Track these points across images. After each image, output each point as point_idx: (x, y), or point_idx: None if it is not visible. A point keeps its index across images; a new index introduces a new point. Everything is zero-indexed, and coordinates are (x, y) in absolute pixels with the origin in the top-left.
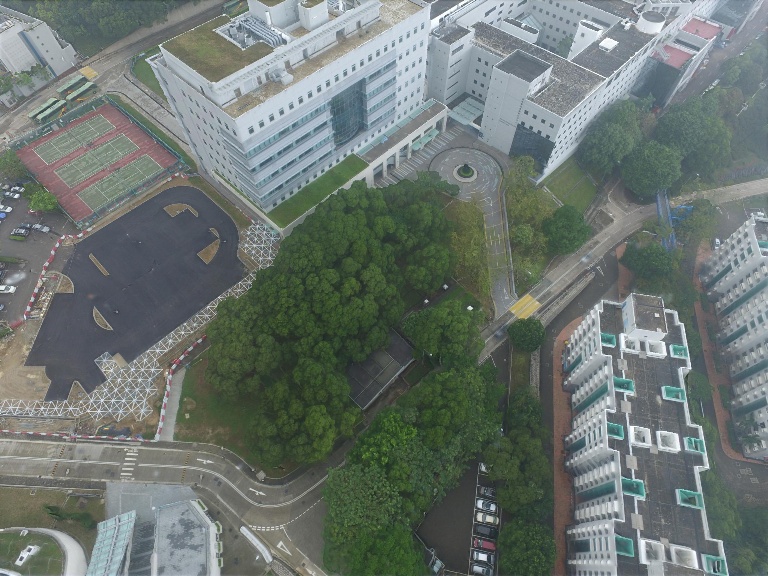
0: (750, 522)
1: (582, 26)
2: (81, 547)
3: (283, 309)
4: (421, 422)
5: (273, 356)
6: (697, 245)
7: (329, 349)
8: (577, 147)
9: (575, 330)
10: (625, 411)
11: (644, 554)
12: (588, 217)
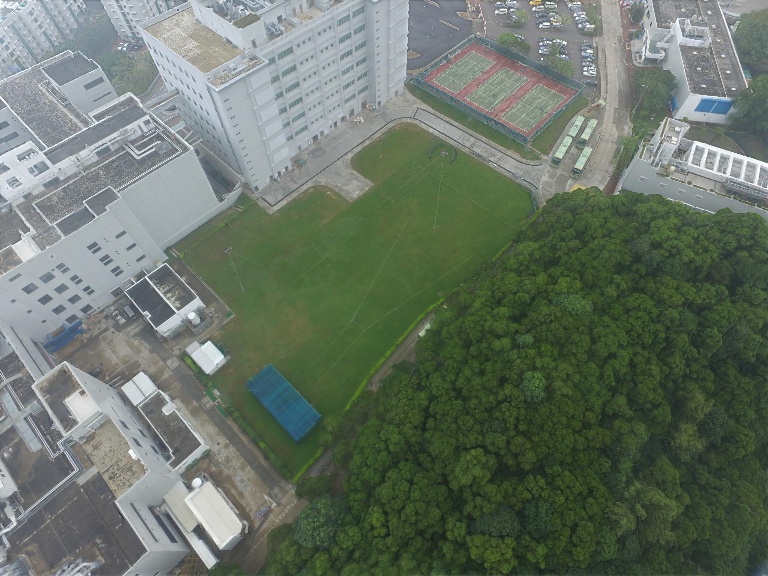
0: None
1: None
2: None
3: None
4: None
5: None
6: None
7: None
8: None
9: None
10: None
11: None
12: None
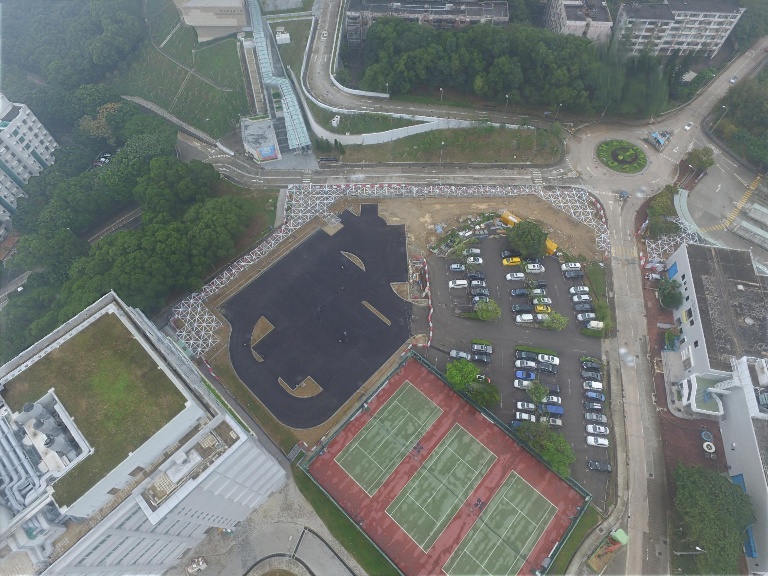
0: None
1: None
2: None
3: None
4: None
5: None
6: None
7: None
8: None
9: None
10: None
11: None
12: None
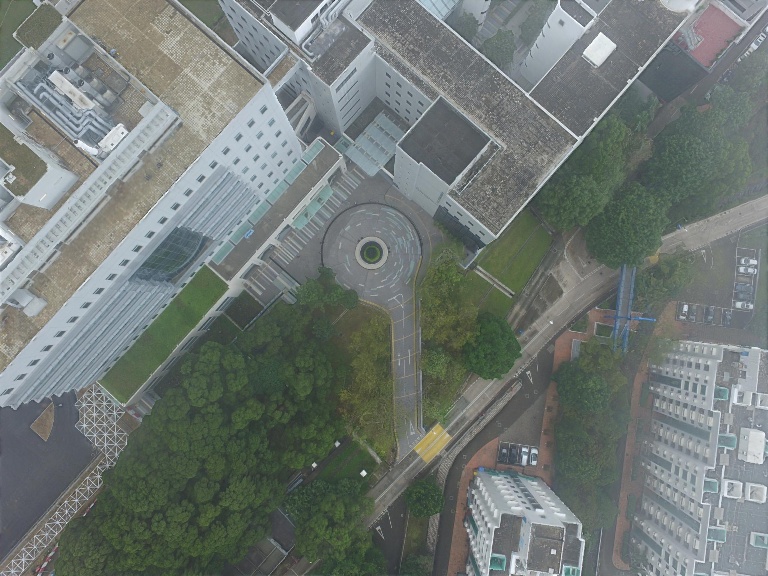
0: None
1: (561, 11)
2: None
3: (133, 552)
4: None
5: None
6: (659, 313)
7: None
8: None
9: (482, 478)
10: None
11: None
12: (531, 290)
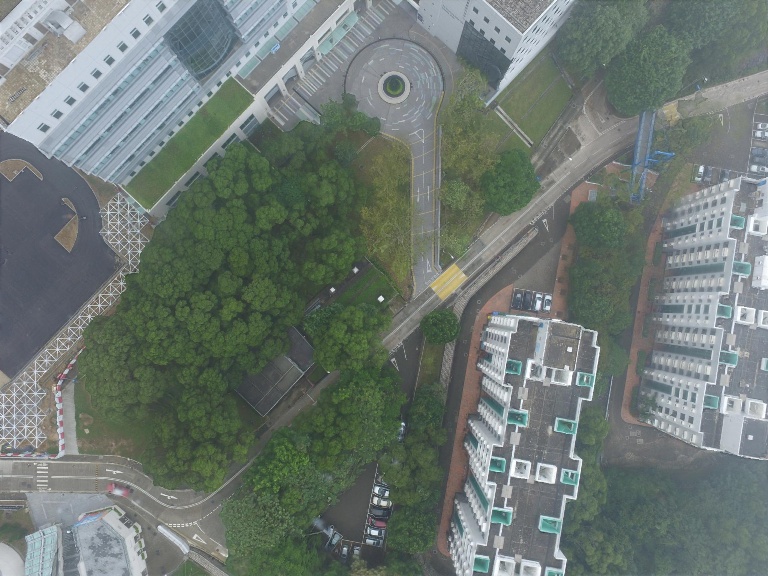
0: (617, 489)
1: None
2: (17, 553)
3: (156, 341)
4: (313, 450)
5: (156, 387)
6: (675, 174)
7: (216, 377)
8: (554, 36)
9: None
10: (513, 443)
11: (497, 570)
12: (550, 142)
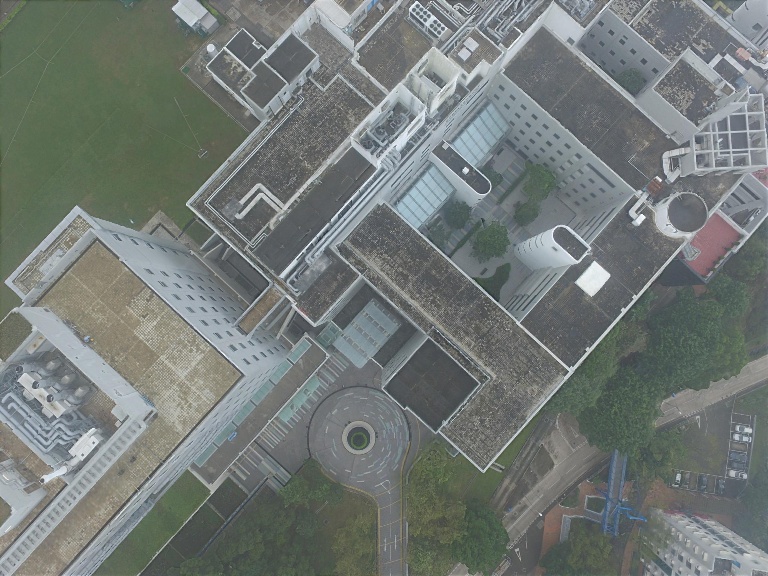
0: None
1: (555, 243)
2: None
3: None
4: None
5: None
6: None
7: None
8: None
9: None
10: None
11: None
12: (522, 462)
